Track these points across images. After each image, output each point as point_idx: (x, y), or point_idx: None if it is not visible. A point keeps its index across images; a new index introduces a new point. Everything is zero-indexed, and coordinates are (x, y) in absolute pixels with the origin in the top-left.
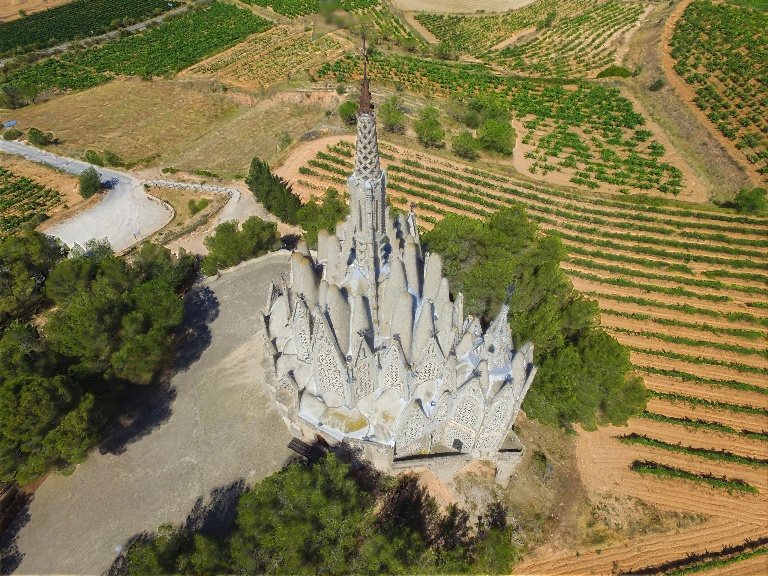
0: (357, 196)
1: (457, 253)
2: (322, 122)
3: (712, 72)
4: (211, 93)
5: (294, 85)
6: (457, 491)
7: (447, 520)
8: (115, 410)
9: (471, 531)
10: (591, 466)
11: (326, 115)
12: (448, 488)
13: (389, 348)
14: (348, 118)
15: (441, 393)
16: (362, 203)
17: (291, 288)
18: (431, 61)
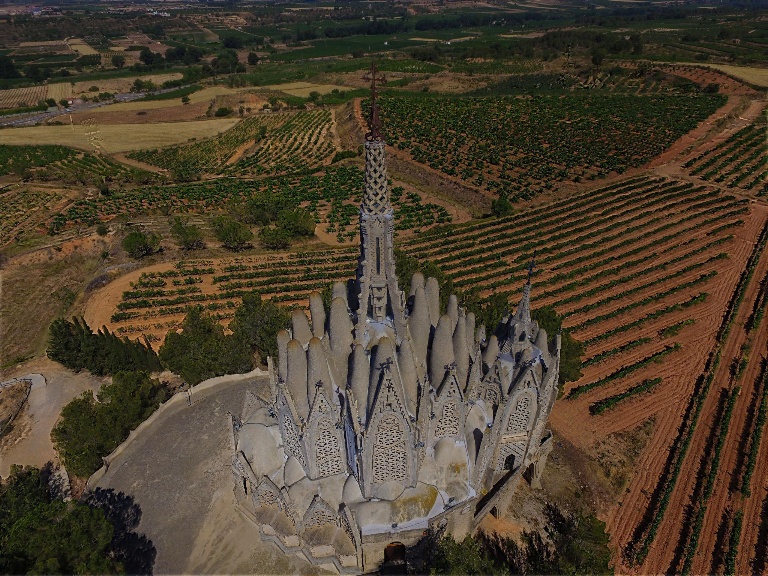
0: (374, 234)
1: None
2: (103, 265)
3: (410, 139)
4: None
5: (29, 245)
6: (516, 518)
7: (530, 550)
8: None
9: (549, 546)
10: (570, 430)
11: (103, 257)
12: (509, 520)
13: (447, 383)
14: (137, 250)
15: (491, 411)
16: (381, 239)
17: None
18: (177, 186)
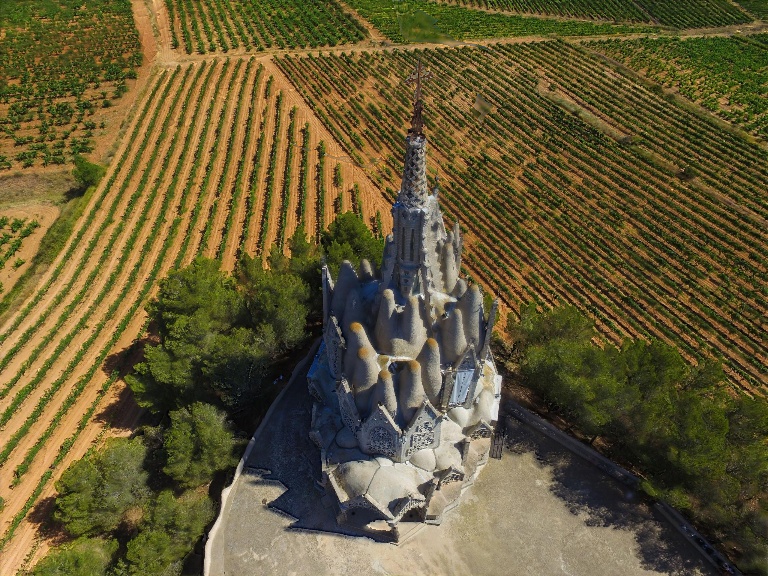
0: None
1: None
2: None
3: None
4: None
5: None
6: None
7: None
8: None
9: None
10: None
11: None
12: None
13: None
14: None
15: None
16: None
17: (418, 406)
18: None
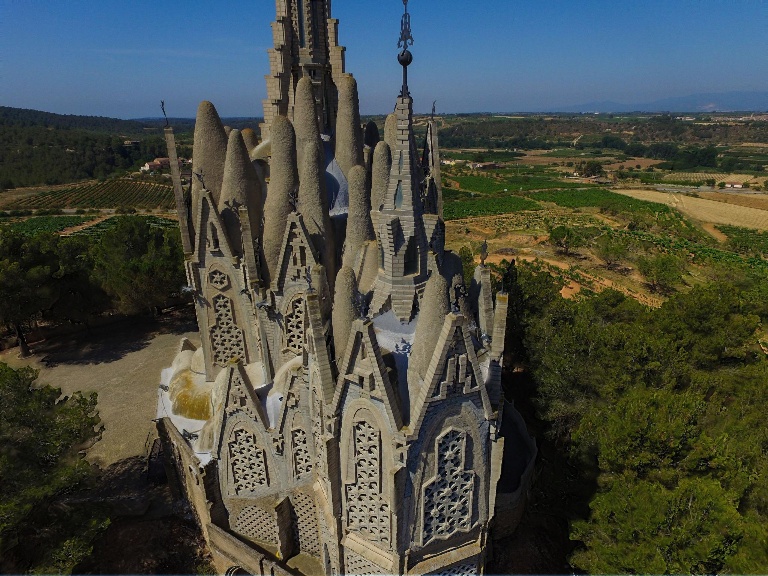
0: None
1: (571, 315)
2: None
3: None
4: (456, 234)
5: (529, 232)
6: None
7: None
8: (97, 337)
9: None
10: None
11: (538, 244)
12: None
13: None
14: (558, 244)
15: None
16: None
17: None
18: None
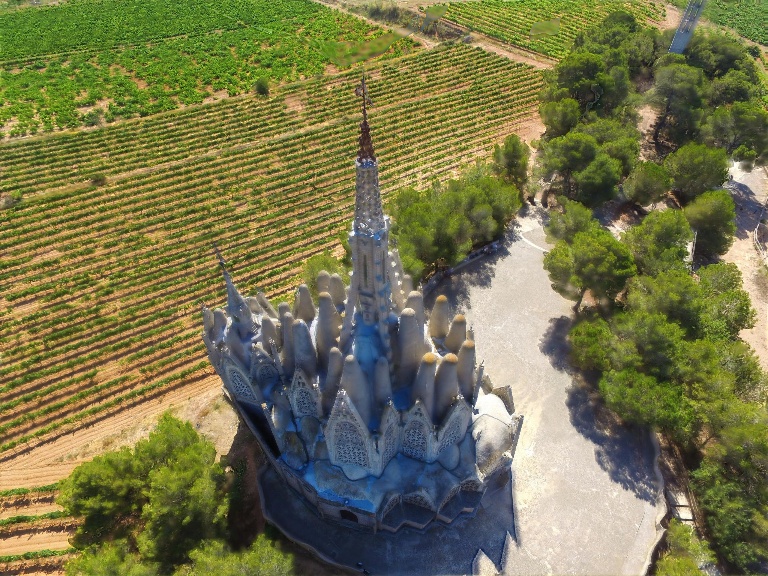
0: None
1: None
2: None
3: None
4: None
5: None
6: None
7: None
8: None
9: None
10: None
11: None
12: None
13: None
14: None
15: None
16: None
17: None
18: None
